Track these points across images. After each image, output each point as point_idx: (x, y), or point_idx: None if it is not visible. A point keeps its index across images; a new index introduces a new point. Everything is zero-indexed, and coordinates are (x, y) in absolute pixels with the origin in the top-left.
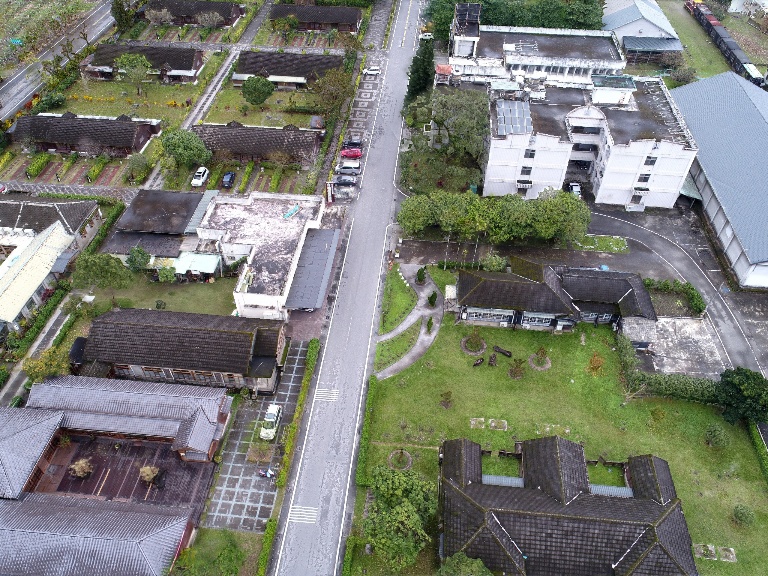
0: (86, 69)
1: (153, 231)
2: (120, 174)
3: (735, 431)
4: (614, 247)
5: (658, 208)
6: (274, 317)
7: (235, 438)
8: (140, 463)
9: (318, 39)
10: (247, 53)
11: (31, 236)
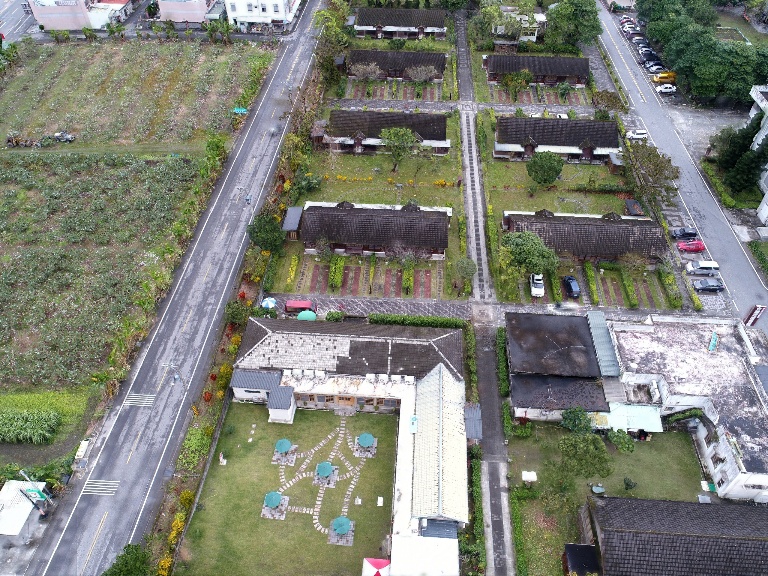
0: (324, 141)
1: (561, 374)
2: (436, 281)
3: None
4: None
5: None
6: None
7: None
8: None
9: (546, 94)
10: (507, 119)
11: (410, 384)
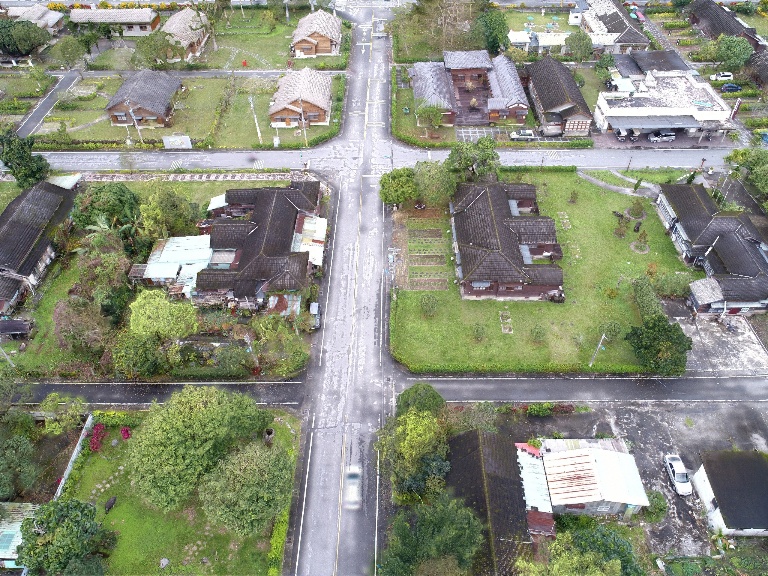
0: None
1: (638, 62)
2: None
3: (629, 360)
4: None
5: None
6: (600, 123)
7: (508, 129)
8: (480, 104)
9: None
10: None
11: None
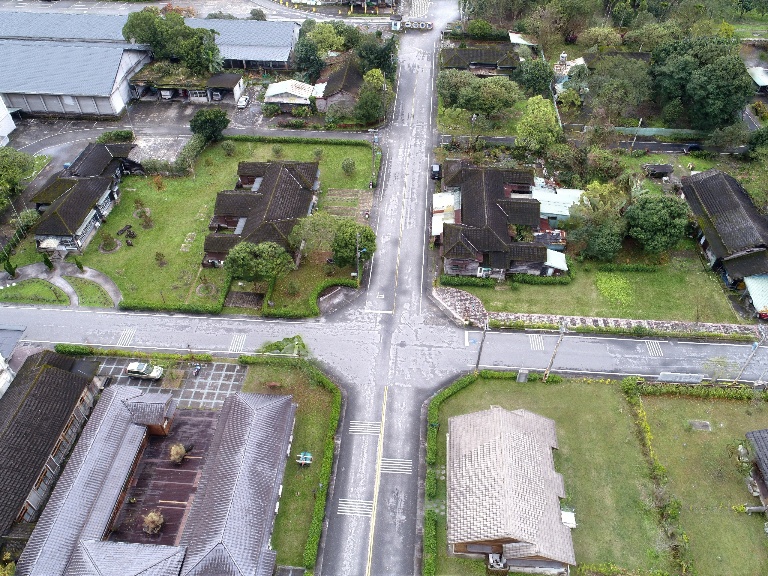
0: None
1: None
2: None
3: None
4: (43, 161)
5: (11, 134)
6: (8, 381)
7: None
8: (159, 473)
9: None
10: None
11: None
